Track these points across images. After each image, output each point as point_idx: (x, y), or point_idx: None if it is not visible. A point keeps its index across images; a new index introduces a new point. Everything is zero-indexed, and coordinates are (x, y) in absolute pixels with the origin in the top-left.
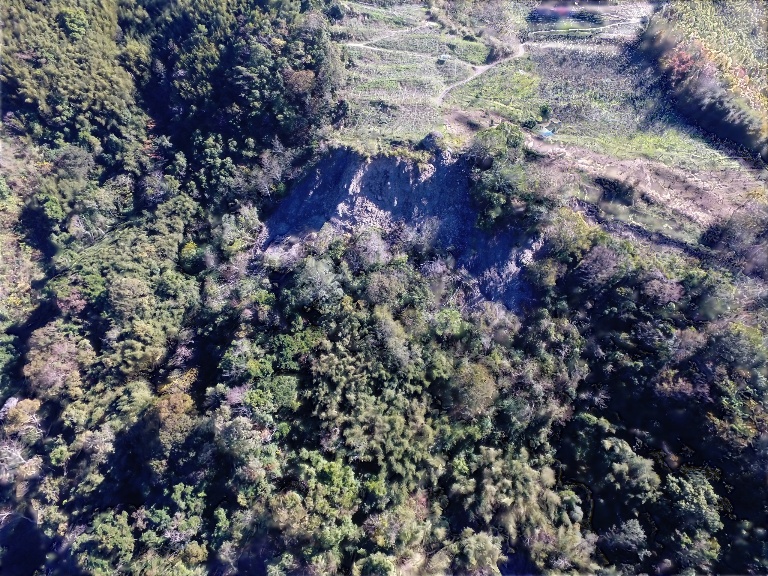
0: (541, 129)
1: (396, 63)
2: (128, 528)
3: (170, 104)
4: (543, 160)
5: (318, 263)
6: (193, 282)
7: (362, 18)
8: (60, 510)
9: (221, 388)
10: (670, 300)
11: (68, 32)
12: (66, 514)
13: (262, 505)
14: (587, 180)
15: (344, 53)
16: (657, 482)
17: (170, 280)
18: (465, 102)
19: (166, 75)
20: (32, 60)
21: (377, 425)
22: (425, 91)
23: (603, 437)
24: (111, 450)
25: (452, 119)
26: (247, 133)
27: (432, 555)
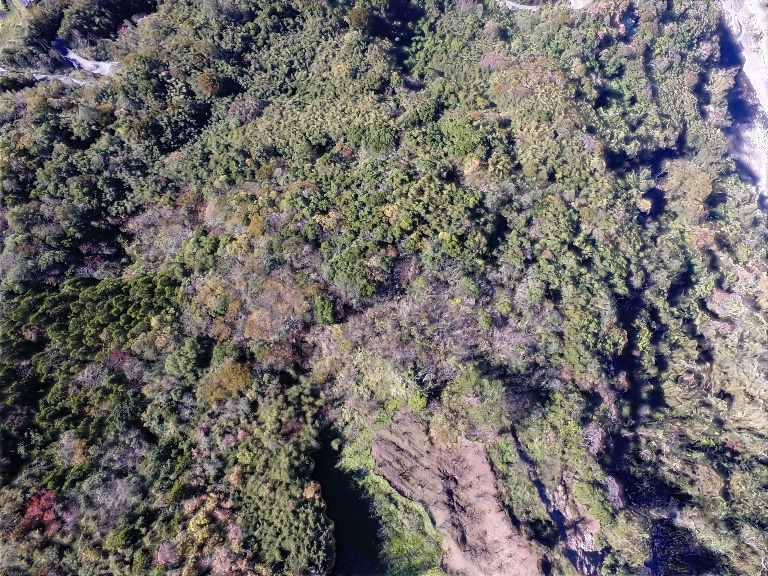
0: None
1: None
2: None
3: None
4: None
5: None
6: None
7: None
8: None
9: None
10: None
11: None
12: None
13: None
14: None
15: None
16: None
17: None
18: None
19: None
20: None
21: None
22: None
23: None
24: None
25: None
26: None
27: None
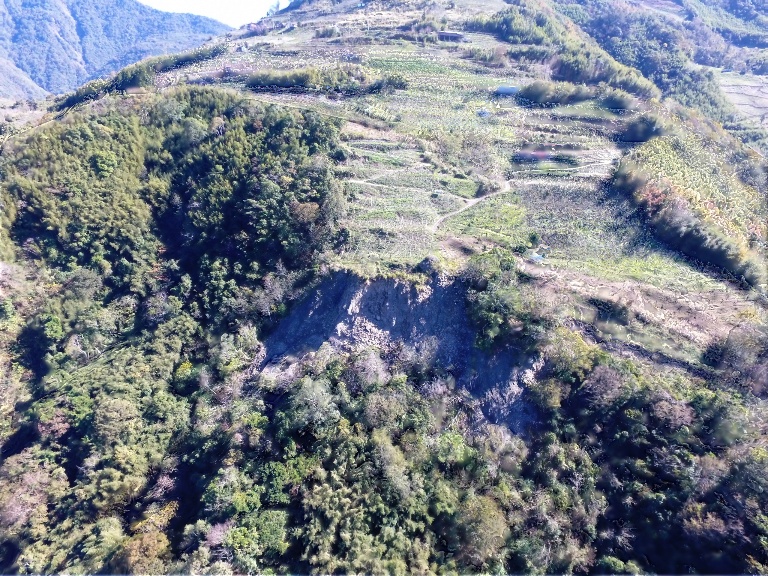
0: (532, 254)
1: (394, 197)
2: None
3: (182, 231)
4: (536, 282)
5: (315, 383)
6: (184, 404)
7: (363, 160)
8: None
9: (202, 525)
10: (682, 423)
11: (98, 171)
12: None
13: None
14: (581, 301)
15: (346, 188)
16: None
17: (161, 402)
18: (458, 230)
19: (182, 207)
20: (60, 194)
21: (375, 571)
22: (421, 220)
23: None
24: None
25: (447, 245)
26: (252, 257)
27: None
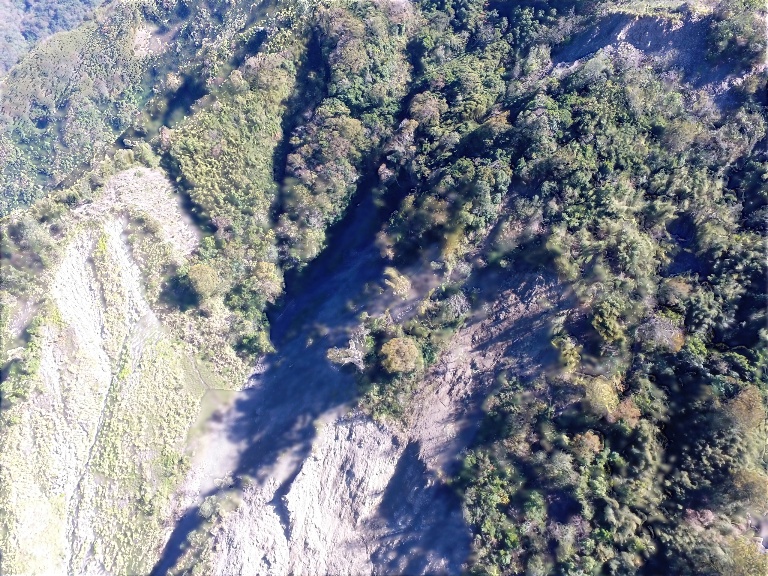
0: None
1: None
2: (472, 163)
3: None
4: None
5: (600, 54)
6: None
7: None
8: (426, 167)
9: (529, 112)
10: None
11: None
12: (429, 168)
13: (546, 157)
14: None
15: None
16: None
17: (494, 78)
18: None
19: None
20: None
21: (615, 139)
22: None
23: (763, 173)
24: (458, 142)
25: None
26: (553, 6)
27: None
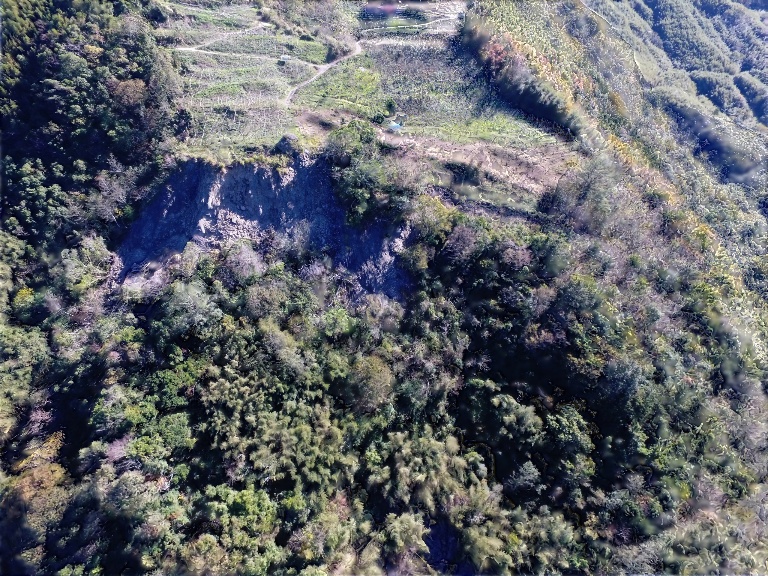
0: (389, 123)
1: (235, 66)
2: None
3: None
4: (396, 152)
5: (188, 287)
6: (37, 333)
7: (188, 20)
8: None
9: (98, 446)
10: (524, 264)
11: None
12: None
13: (173, 559)
14: (438, 167)
15: (175, 58)
16: (540, 424)
17: (5, 336)
18: (313, 102)
19: None
20: None
21: (284, 440)
22: (271, 94)
23: (491, 396)
24: None
25: (303, 120)
26: (74, 154)
27: (361, 551)
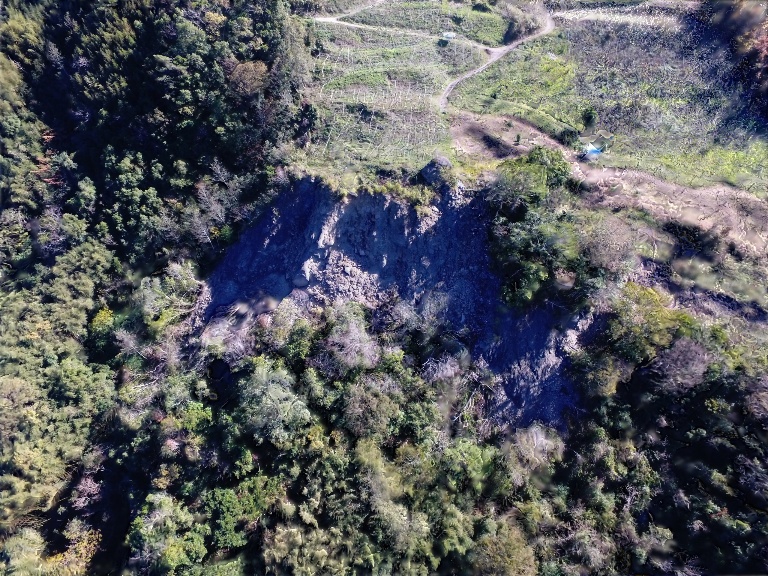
0: None
1: (382, 46)
2: None
3: (72, 107)
4: (592, 196)
5: (268, 388)
6: (105, 373)
7: None
8: None
9: None
10: None
11: None
12: None
13: None
14: (656, 228)
15: (309, 33)
16: None
17: (68, 377)
18: (479, 106)
19: (64, 65)
20: None
21: None
22: (423, 87)
23: None
24: None
25: (462, 134)
26: (176, 152)
27: None
